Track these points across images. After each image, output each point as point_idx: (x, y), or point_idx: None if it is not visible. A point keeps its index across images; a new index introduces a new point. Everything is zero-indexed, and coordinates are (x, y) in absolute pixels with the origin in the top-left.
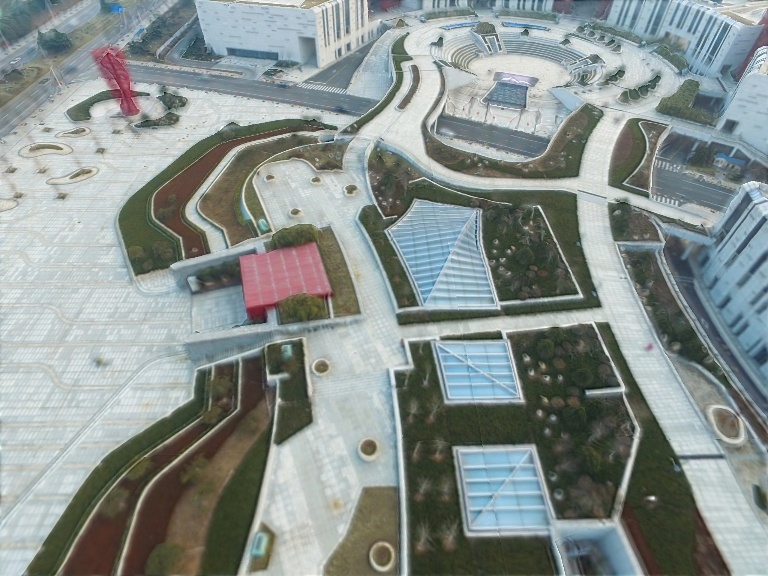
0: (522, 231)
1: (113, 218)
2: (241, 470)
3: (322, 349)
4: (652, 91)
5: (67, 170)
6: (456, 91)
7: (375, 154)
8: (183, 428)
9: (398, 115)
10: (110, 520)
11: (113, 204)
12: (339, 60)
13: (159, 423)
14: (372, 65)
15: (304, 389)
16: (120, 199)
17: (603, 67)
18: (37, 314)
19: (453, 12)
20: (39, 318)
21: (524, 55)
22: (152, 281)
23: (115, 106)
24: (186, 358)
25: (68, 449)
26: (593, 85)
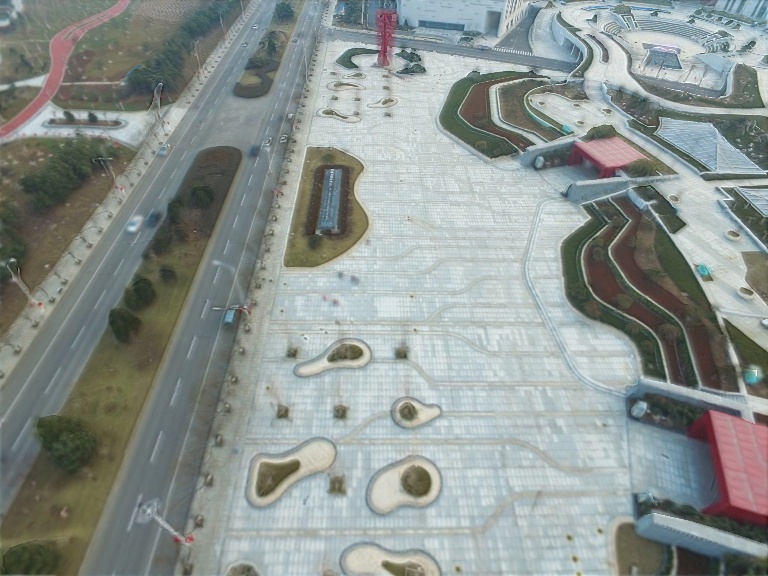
0: (751, 135)
1: (437, 128)
2: (659, 245)
3: (666, 191)
4: None
5: (374, 99)
6: None
7: None
8: None
9: (606, 66)
10: (600, 264)
11: (428, 120)
12: (508, 32)
13: (581, 228)
14: (541, 36)
15: (671, 209)
16: (430, 118)
17: (732, 40)
18: (441, 178)
19: None
20: (445, 180)
21: (656, 32)
22: (502, 162)
23: (366, 60)
24: (565, 200)
25: (532, 240)
26: (733, 52)
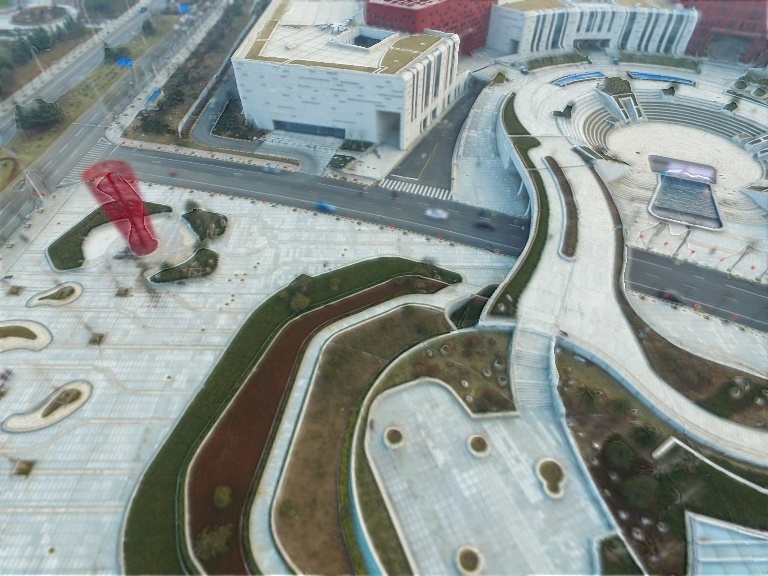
0: None
1: (114, 534)
2: None
3: None
4: None
5: (39, 391)
6: None
7: (560, 366)
8: None
9: (568, 269)
10: None
11: (115, 489)
12: (425, 134)
13: None
14: (475, 145)
15: None
16: (127, 473)
17: None
18: None
19: (560, 58)
20: None
21: (672, 123)
22: None
23: (121, 233)
24: None
25: None
26: None
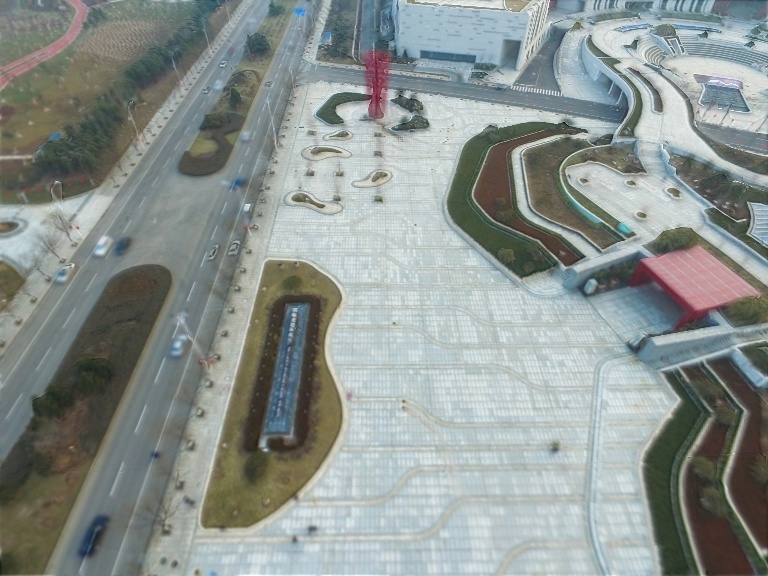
0: None
1: (444, 221)
2: None
3: None
4: None
5: (362, 173)
6: None
7: None
8: (699, 429)
9: (660, 118)
10: (715, 519)
11: (433, 207)
12: (529, 63)
13: (668, 424)
14: (569, 68)
15: None
16: (435, 202)
17: None
18: (452, 316)
19: (617, 14)
20: (457, 320)
21: (707, 57)
22: (537, 283)
23: (355, 109)
24: (636, 360)
25: (595, 449)
26: None
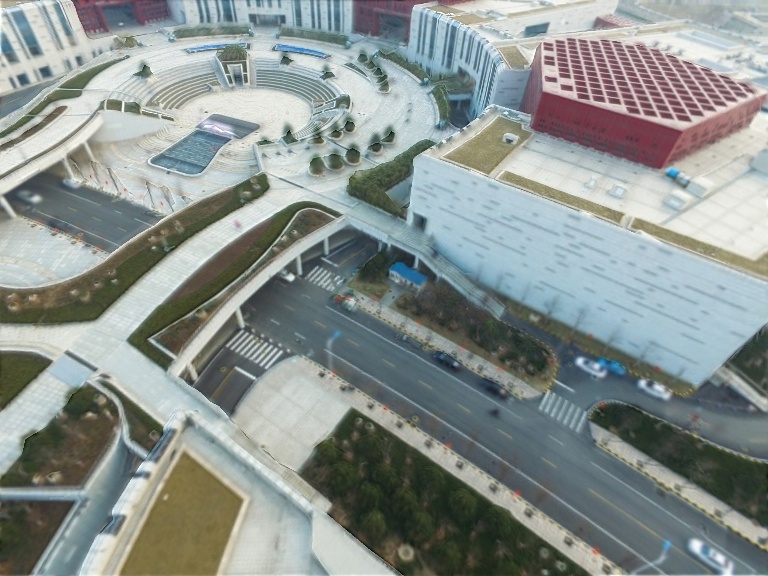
0: None
1: None
2: None
3: None
4: (374, 154)
5: None
6: (134, 142)
7: None
8: None
9: None
10: None
11: None
12: (19, 90)
13: None
14: None
15: None
16: None
17: (346, 113)
18: None
19: (220, 29)
20: None
21: (277, 90)
22: None
23: None
24: None
25: None
26: (303, 142)
